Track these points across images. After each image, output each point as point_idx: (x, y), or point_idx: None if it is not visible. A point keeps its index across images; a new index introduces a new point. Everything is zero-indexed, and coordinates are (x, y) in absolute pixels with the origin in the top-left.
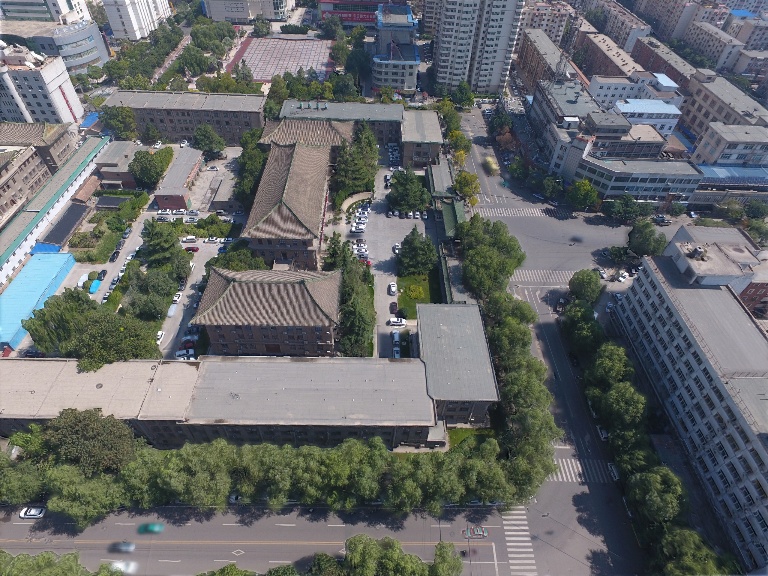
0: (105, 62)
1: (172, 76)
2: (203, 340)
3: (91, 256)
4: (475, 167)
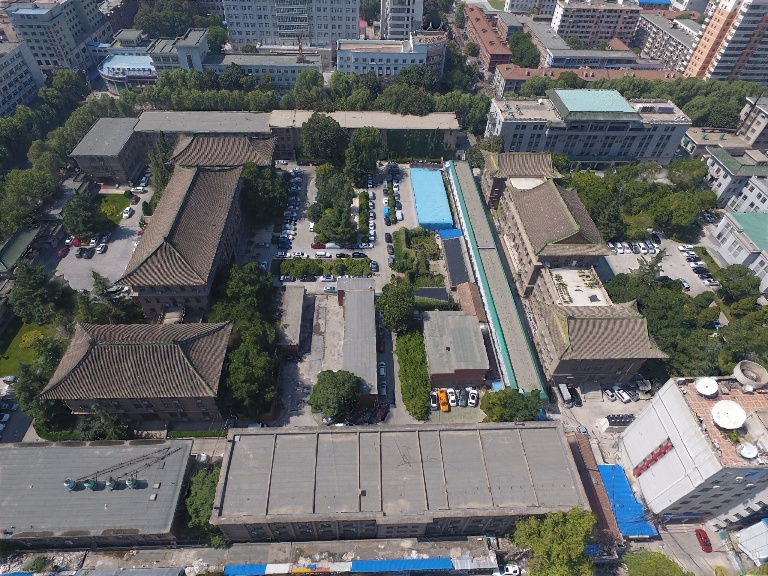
0: None
1: None
2: (286, 179)
3: None
4: None
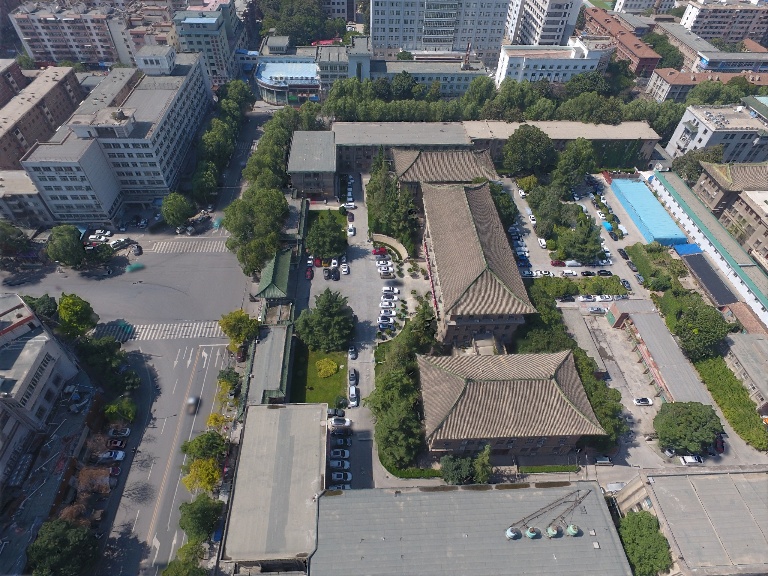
0: None
1: None
2: None
3: None
4: (188, 441)
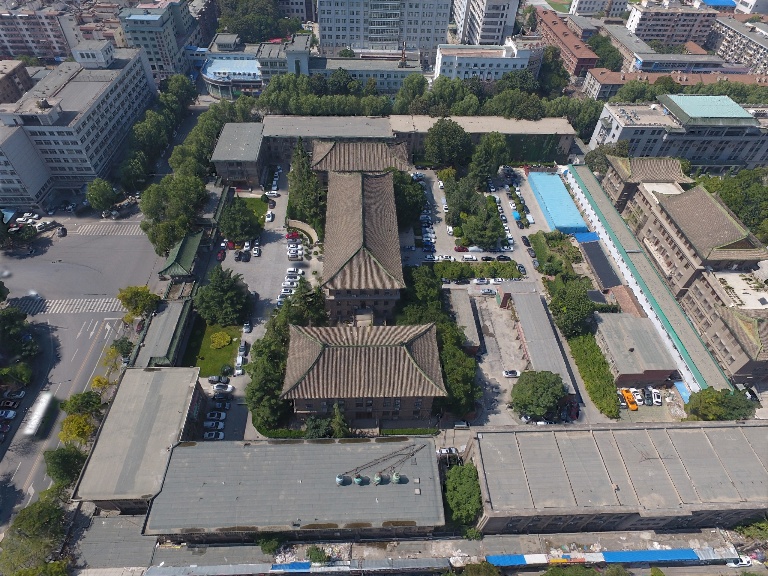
0: None
1: None
2: None
3: None
4: None
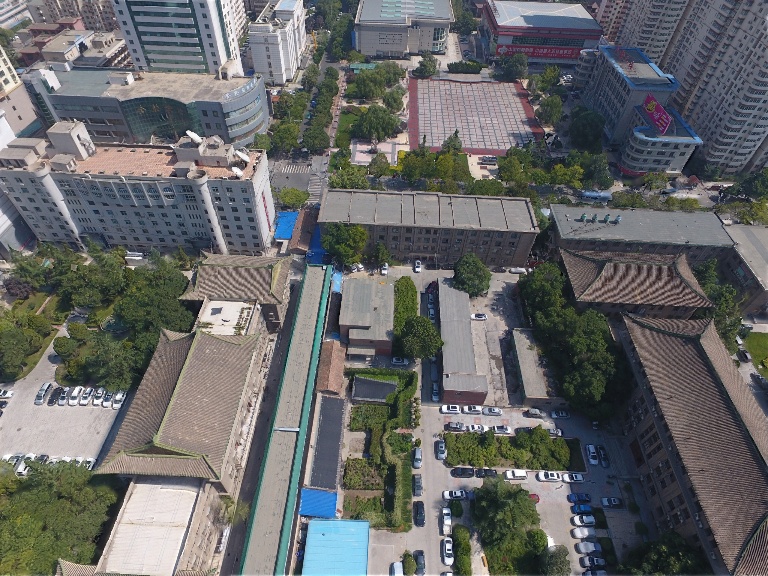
0: (266, 124)
1: (349, 142)
2: None
3: (395, 523)
4: None
